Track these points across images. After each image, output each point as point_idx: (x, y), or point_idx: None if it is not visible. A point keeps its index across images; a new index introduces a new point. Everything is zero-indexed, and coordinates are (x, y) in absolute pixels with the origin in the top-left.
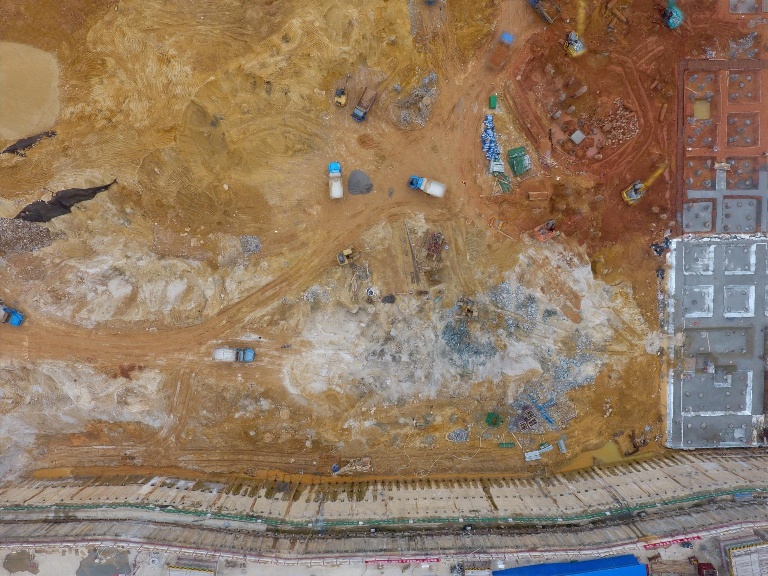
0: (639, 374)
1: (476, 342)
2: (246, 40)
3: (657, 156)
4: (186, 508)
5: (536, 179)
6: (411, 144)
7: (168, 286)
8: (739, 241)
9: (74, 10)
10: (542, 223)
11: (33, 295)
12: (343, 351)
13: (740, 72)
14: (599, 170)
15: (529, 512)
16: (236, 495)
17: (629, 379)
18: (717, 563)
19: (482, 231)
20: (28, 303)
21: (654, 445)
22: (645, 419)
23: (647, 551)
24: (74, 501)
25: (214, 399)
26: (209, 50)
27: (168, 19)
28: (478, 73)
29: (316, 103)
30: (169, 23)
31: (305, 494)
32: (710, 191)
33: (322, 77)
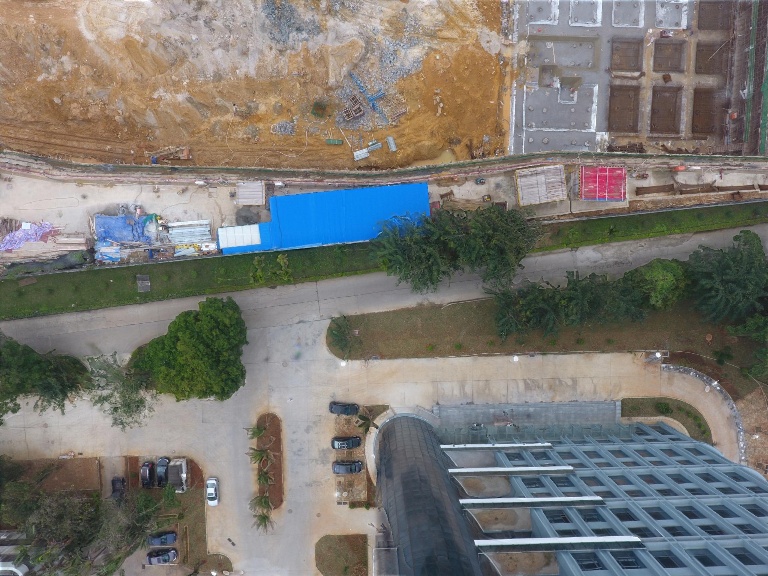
0: (469, 61)
1: (298, 19)
2: None
3: None
4: None
5: None
6: None
7: None
8: None
9: None
10: None
11: None
12: None
13: None
14: None
15: (332, 170)
16: None
17: (459, 68)
18: (511, 202)
19: None
20: None
21: None
22: (483, 127)
23: (439, 188)
24: None
25: (8, 48)
26: None
27: None
28: None
29: None
30: None
31: None
32: None
33: None
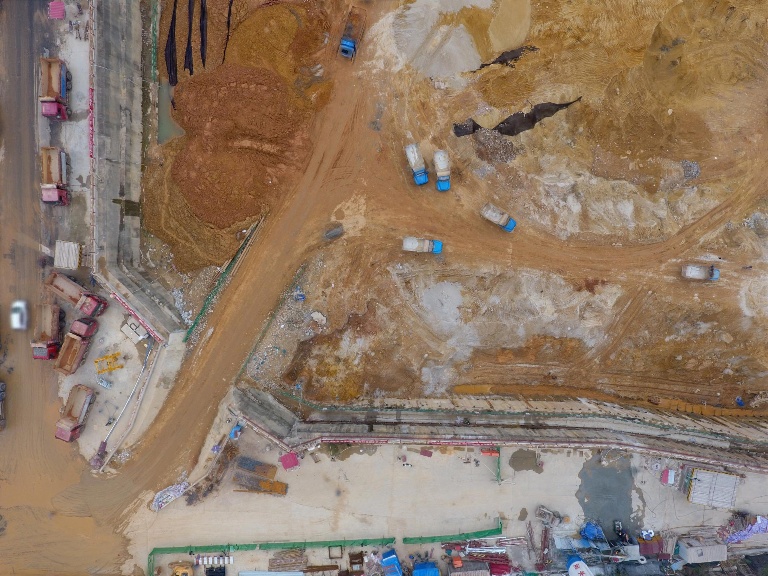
0: None
1: None
2: None
3: None
4: (652, 422)
5: None
6: None
7: (617, 206)
8: None
9: None
10: None
11: (523, 202)
12: None
13: None
14: None
15: None
16: (671, 417)
17: None
18: None
19: None
20: (517, 210)
21: None
22: None
23: None
24: (542, 409)
25: (661, 319)
26: None
27: None
28: None
29: (764, 32)
30: None
31: (724, 422)
32: None
33: None
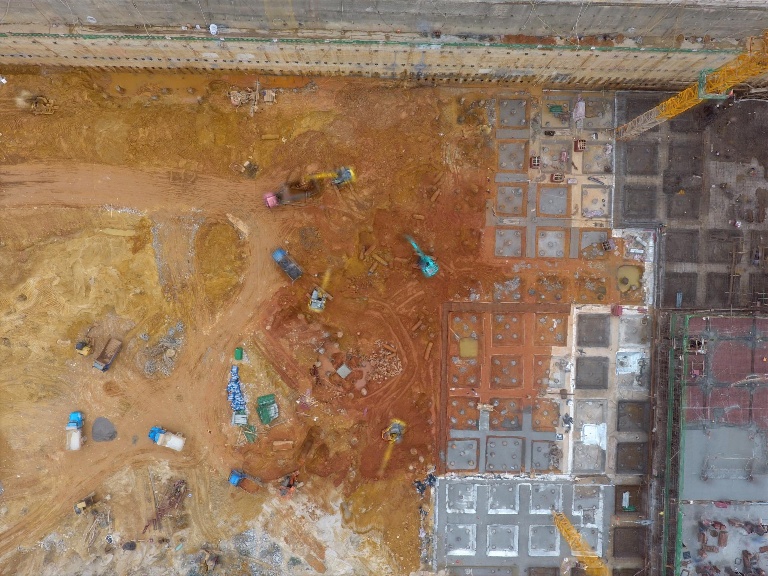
0: None
1: None
2: None
3: (421, 395)
4: None
5: (285, 426)
6: (156, 393)
7: None
8: (503, 481)
9: None
10: (286, 474)
11: None
12: None
13: (505, 314)
14: (364, 405)
15: None
16: None
17: None
18: None
19: (226, 480)
20: None
21: None
22: None
23: None
24: None
25: None
26: None
27: None
28: (226, 324)
29: (61, 352)
30: None
31: None
32: (473, 431)
33: (67, 327)
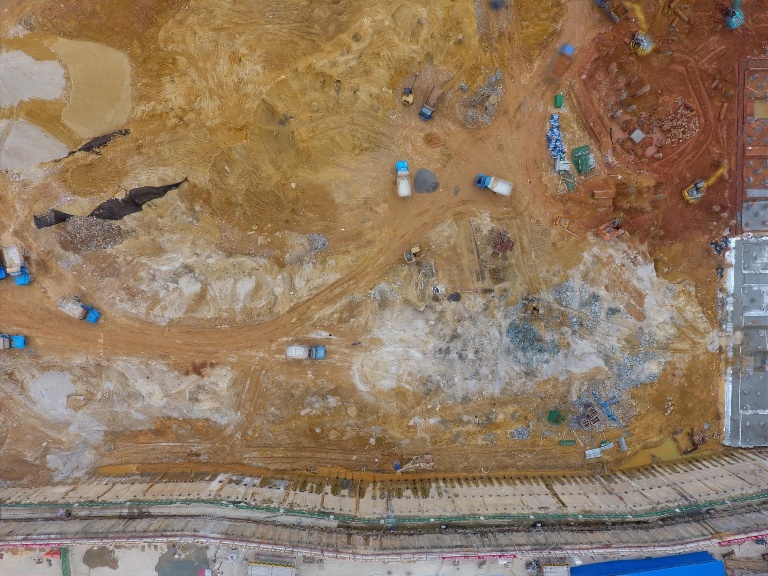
0: (702, 372)
1: (540, 340)
2: (314, 39)
3: (717, 155)
4: (258, 504)
5: (600, 178)
6: (477, 143)
7: (237, 284)
8: None
9: (146, 9)
10: (607, 221)
11: (109, 292)
12: (412, 348)
13: None
14: (659, 169)
15: (598, 509)
16: (303, 492)
17: (691, 377)
18: None
19: (547, 229)
20: (104, 300)
21: (712, 443)
22: (704, 417)
23: (721, 548)
24: (147, 497)
25: (283, 396)
26: (277, 49)
27: (237, 18)
28: (544, 72)
29: (383, 102)
30: (238, 22)
31: (369, 491)
32: None
33: (389, 76)
